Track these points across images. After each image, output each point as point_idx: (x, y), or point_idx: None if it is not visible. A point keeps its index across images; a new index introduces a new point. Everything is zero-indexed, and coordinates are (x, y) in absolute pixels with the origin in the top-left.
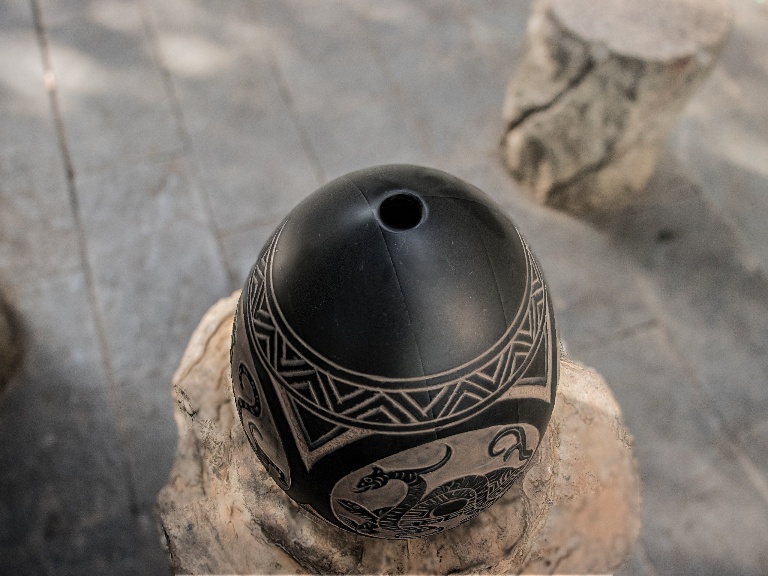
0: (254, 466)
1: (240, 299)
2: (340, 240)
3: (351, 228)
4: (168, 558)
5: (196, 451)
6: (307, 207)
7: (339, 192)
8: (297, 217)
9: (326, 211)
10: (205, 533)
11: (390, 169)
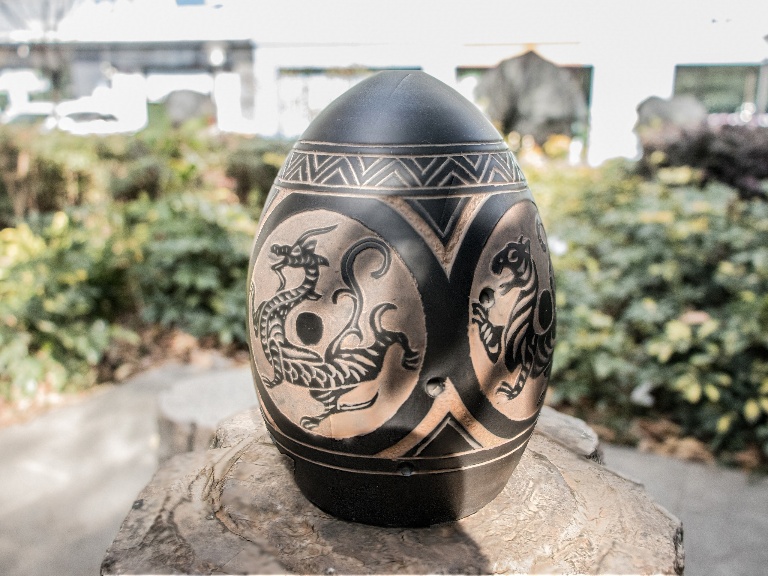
0: (547, 516)
1: (502, 232)
2: (445, 85)
3: (434, 79)
4: (682, 540)
5: (601, 569)
6: (427, 118)
7: (408, 94)
8: (438, 124)
9: (430, 93)
10: (632, 525)
11: (359, 96)
